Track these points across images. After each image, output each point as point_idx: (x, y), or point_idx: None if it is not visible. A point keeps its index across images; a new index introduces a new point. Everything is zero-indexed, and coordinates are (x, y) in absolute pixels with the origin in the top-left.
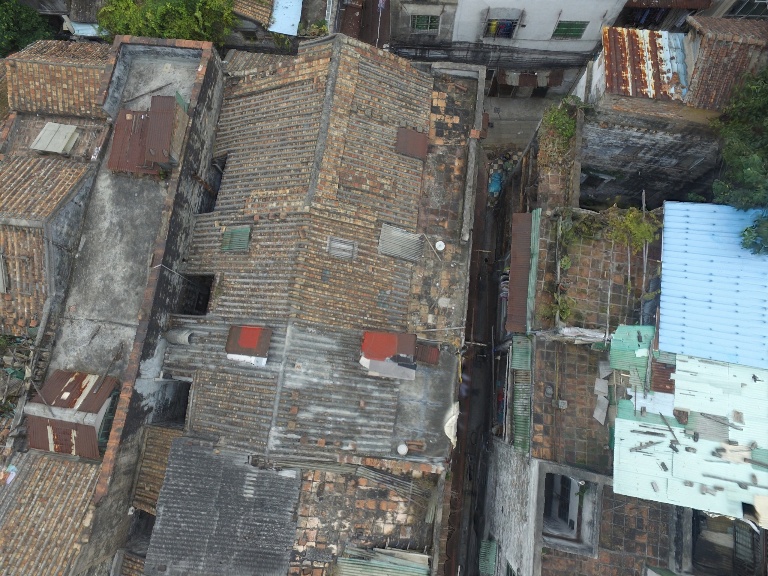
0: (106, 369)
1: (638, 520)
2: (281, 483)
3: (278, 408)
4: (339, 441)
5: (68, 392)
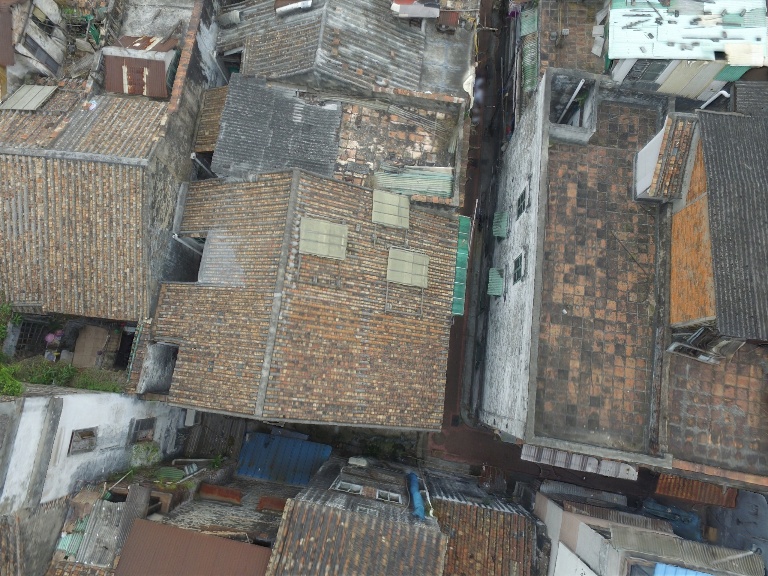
0: (169, 33)
1: (630, 126)
2: (324, 114)
3: (323, 37)
4: (374, 75)
5: (139, 43)
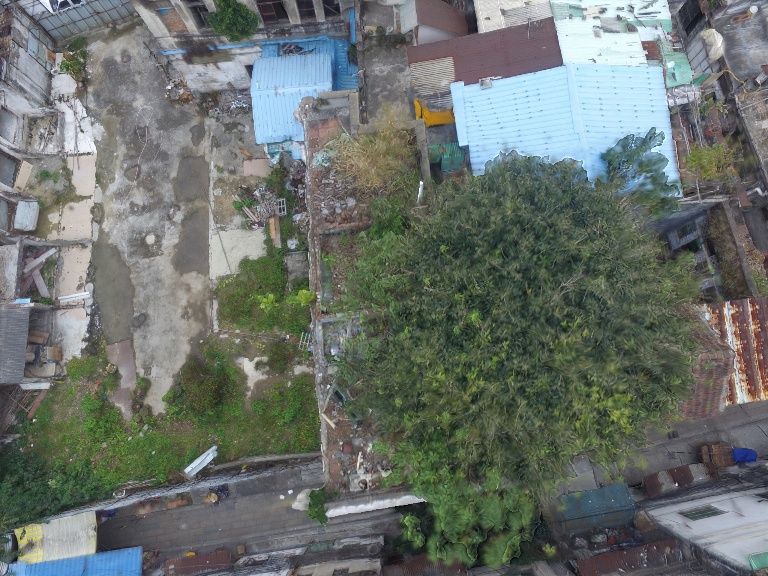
0: None
1: None
2: None
3: None
4: None
5: None
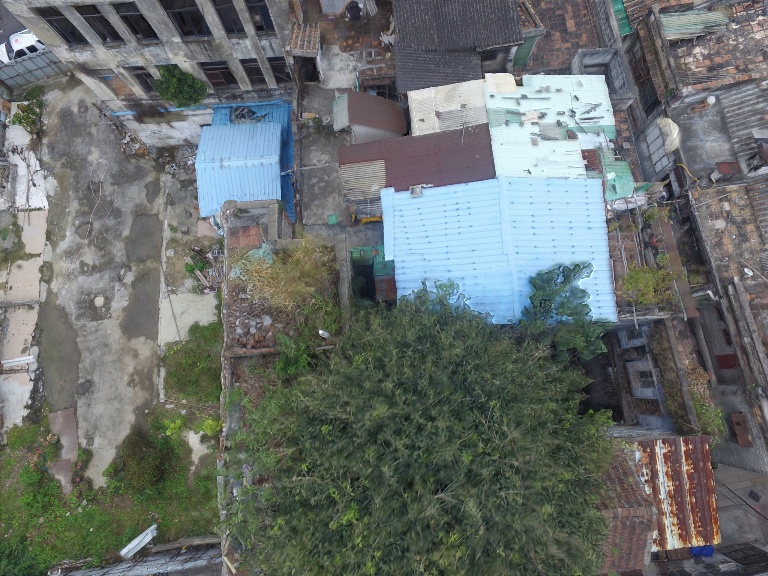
0: None
1: None
2: None
3: None
4: None
5: None
